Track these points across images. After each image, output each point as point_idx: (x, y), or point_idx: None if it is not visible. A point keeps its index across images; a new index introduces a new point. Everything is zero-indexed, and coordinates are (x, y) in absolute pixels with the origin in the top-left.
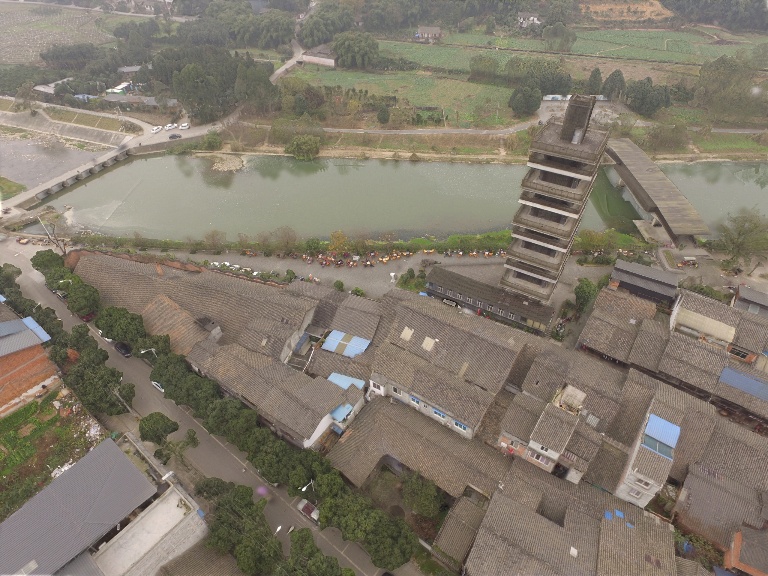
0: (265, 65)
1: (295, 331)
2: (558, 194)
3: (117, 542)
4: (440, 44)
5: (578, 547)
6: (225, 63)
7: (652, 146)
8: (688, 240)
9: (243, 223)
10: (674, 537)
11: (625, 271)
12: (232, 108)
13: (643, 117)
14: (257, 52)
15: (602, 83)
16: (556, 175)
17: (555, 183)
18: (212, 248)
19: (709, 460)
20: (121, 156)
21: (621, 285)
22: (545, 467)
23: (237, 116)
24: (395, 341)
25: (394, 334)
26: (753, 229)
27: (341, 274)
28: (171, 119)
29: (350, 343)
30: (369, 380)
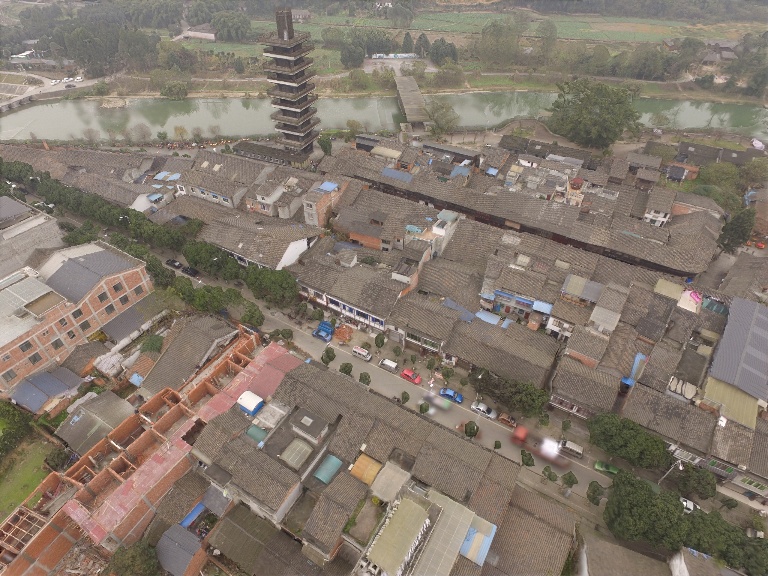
0: (152, 37)
1: (135, 168)
2: (281, 70)
3: (9, 231)
4: (308, 23)
5: (264, 228)
6: (115, 33)
7: (438, 84)
8: (422, 128)
9: (120, 136)
10: (325, 231)
11: (362, 137)
12: (120, 66)
13: (439, 67)
14: (150, 31)
15: (414, 44)
16: (282, 61)
17: (283, 66)
18: (90, 143)
19: (358, 204)
20: (24, 101)
21: (361, 147)
22: (269, 213)
23: (124, 72)
24: (197, 169)
25: (197, 165)
26: (440, 109)
27: (181, 153)
28: (67, 74)
29: (172, 175)
30: (177, 186)
